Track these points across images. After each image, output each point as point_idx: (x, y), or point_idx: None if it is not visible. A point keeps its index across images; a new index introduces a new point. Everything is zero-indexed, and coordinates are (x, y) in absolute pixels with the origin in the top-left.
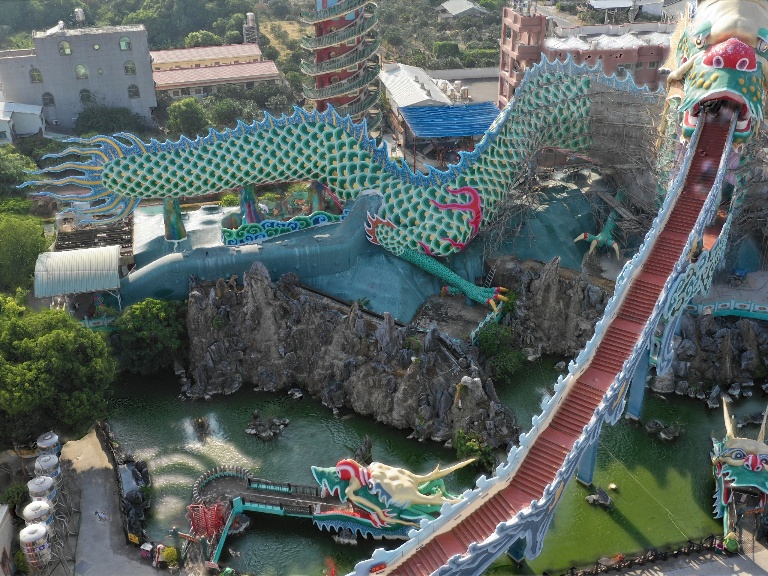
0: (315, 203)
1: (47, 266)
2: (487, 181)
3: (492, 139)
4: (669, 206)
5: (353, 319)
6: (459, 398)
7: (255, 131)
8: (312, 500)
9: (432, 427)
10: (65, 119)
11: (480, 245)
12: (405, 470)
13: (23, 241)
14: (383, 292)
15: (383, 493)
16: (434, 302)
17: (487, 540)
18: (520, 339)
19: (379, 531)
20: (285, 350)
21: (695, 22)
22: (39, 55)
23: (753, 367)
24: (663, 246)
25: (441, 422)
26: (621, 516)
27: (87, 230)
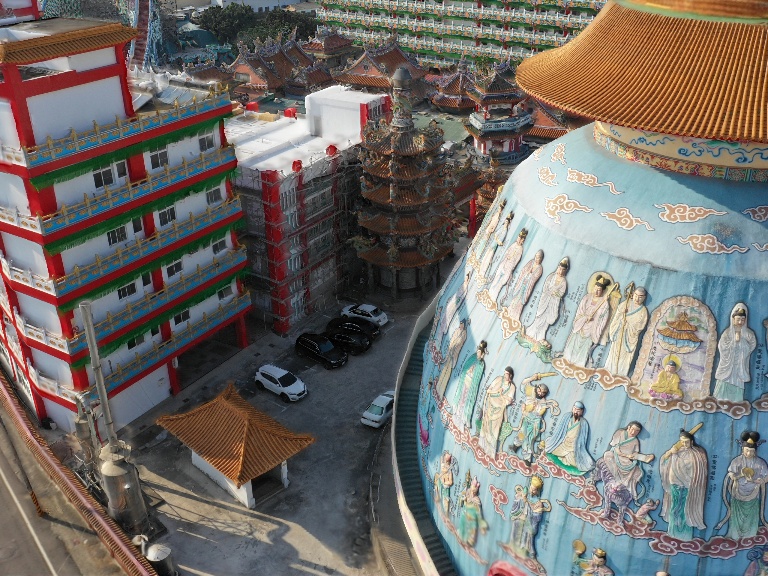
0: None
1: None
2: None
3: (45, 6)
4: None
5: None
6: None
7: None
8: None
9: None
10: None
11: None
12: None
13: None
14: None
15: None
16: None
17: None
18: None
19: None
20: None
21: None
22: None
23: None
24: (141, 18)
25: None
26: None
27: None
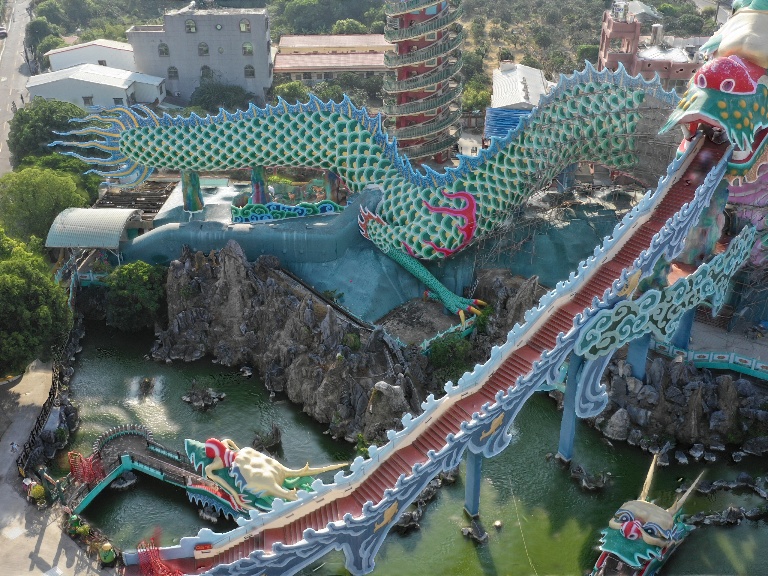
0: (328, 192)
1: (64, 219)
2: (488, 188)
3: (502, 146)
4: (622, 235)
5: (303, 308)
6: (371, 402)
7: (268, 115)
8: (194, 472)
9: (347, 427)
10: (187, 92)
11: (478, 254)
12: (274, 460)
13: (56, 195)
14: (359, 287)
15: (240, 478)
16: (414, 305)
17: (297, 543)
18: (485, 356)
19: (239, 514)
20: (247, 328)
21: (713, 36)
22: (168, 31)
23: (724, 430)
24: (601, 277)
25: (356, 423)
26: (488, 555)
27: (131, 193)
